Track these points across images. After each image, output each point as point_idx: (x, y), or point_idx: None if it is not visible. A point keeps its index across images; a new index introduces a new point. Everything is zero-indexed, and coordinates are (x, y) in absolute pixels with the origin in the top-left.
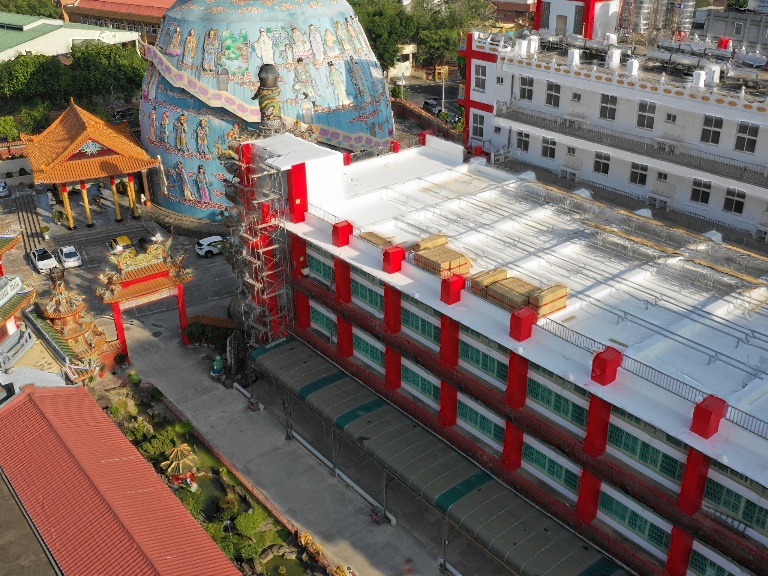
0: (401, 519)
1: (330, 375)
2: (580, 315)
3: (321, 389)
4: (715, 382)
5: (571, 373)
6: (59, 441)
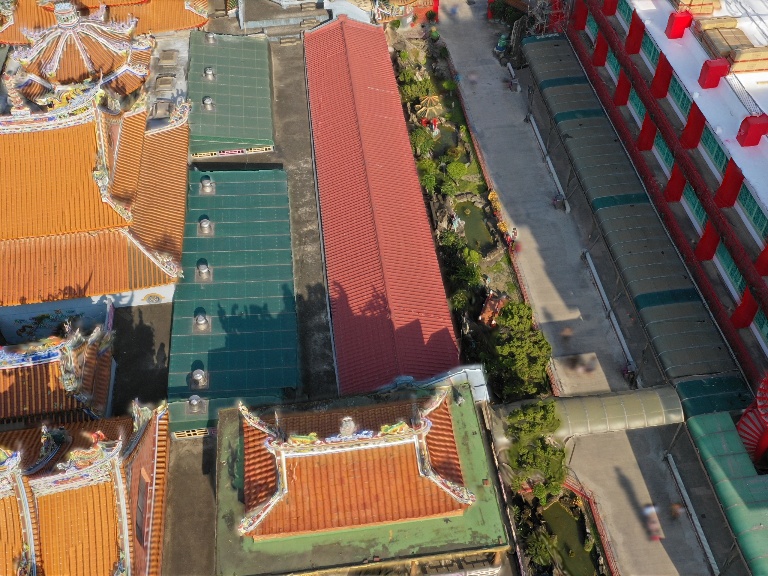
0: (575, 211)
1: (574, 77)
2: None
3: (559, 86)
4: None
5: (722, 127)
6: (347, 63)
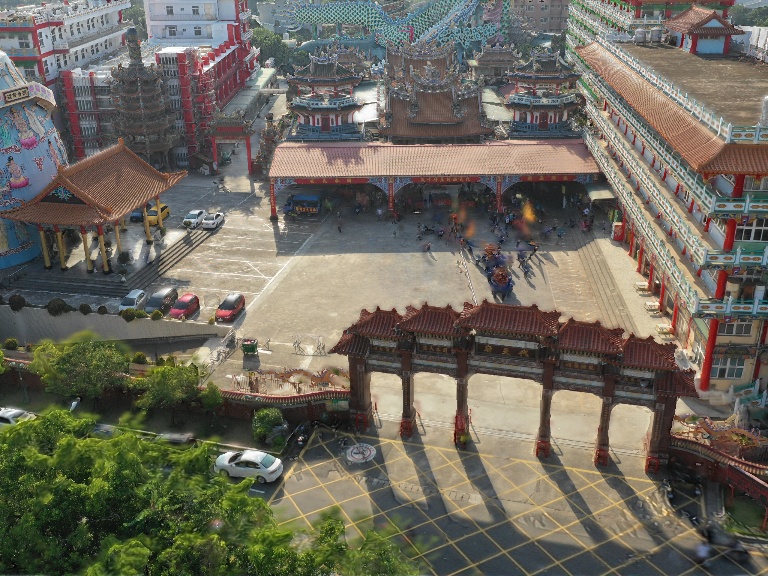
0: None
1: None
2: None
3: None
4: None
5: None
6: None
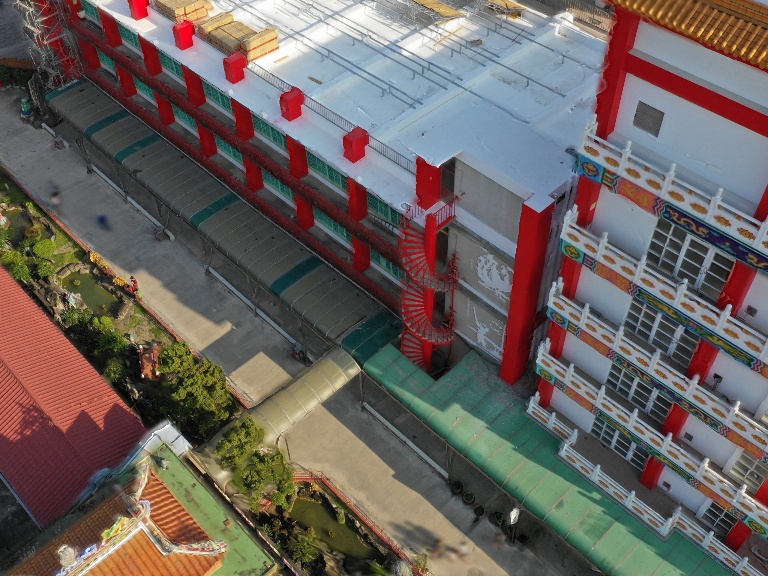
0: (179, 235)
1: (114, 114)
2: (293, 55)
3: (105, 128)
4: (381, 113)
5: (266, 111)
6: None
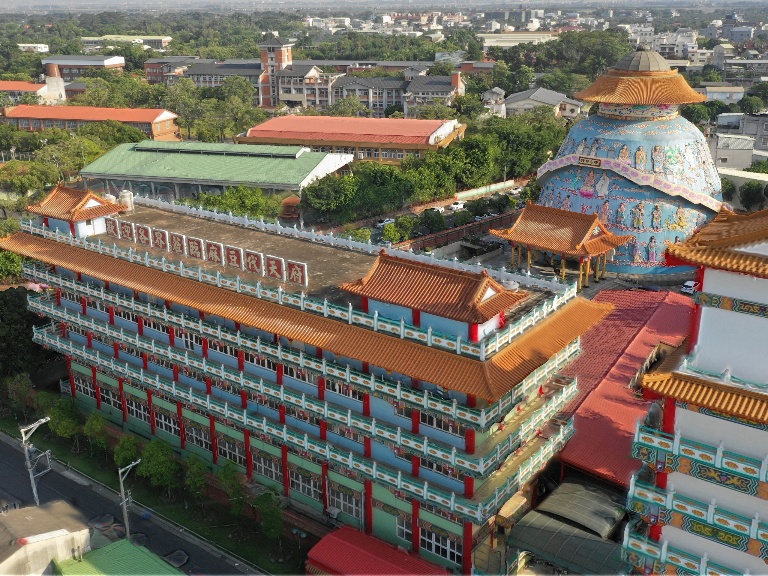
0: None
1: None
2: None
3: None
4: None
5: None
6: None
